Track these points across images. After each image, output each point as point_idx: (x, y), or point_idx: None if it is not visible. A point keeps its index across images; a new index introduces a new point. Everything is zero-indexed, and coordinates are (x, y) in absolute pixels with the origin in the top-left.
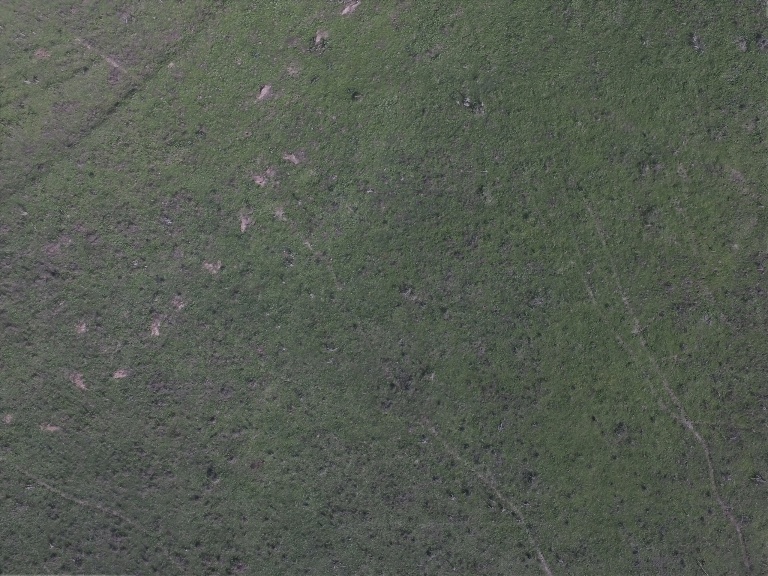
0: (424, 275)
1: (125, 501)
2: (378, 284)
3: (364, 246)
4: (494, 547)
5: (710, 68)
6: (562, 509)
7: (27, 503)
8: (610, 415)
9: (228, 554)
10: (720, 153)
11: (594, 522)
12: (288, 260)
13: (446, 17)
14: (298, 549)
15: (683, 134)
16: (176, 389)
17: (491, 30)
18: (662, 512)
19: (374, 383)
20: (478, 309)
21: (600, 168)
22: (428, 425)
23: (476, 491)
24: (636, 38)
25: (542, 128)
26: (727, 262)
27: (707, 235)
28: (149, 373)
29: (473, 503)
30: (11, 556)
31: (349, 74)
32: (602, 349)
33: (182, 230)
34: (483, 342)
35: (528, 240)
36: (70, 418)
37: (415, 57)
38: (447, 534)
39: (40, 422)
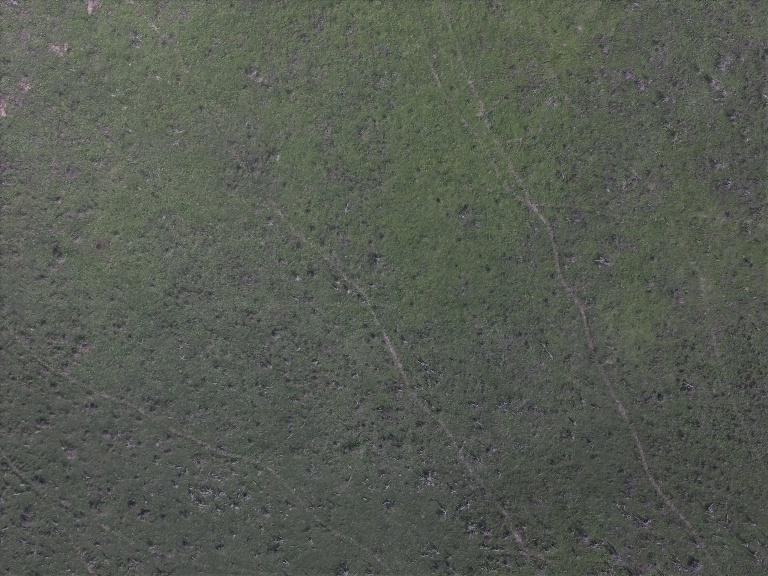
0: (270, 58)
1: None
2: (224, 67)
3: (211, 29)
4: (339, 328)
5: None
6: (407, 291)
7: None
8: (455, 198)
9: (74, 334)
10: None
11: (439, 304)
12: (134, 42)
13: None
14: (144, 330)
15: None
16: (22, 169)
17: None
18: (506, 294)
19: (220, 166)
20: (324, 92)
21: None
22: (274, 207)
23: (322, 273)
24: None
25: None
26: (572, 45)
27: (552, 18)
28: None
29: (318, 284)
30: None
31: None
32: (447, 132)
33: (29, 12)
34: (329, 125)
35: (374, 24)
36: None
37: None
38: (292, 315)
39: None
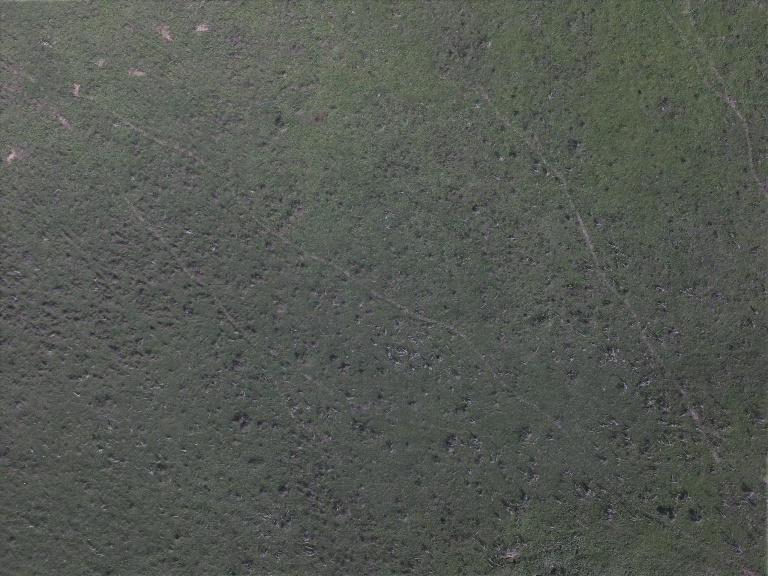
0: None
1: (200, 144)
2: None
3: None
4: (536, 208)
5: None
6: (603, 177)
7: (113, 140)
8: (656, 90)
9: (290, 198)
10: None
11: (633, 191)
12: None
13: None
14: (354, 199)
15: None
16: (252, 44)
17: None
18: (699, 185)
19: (434, 49)
20: None
21: None
22: (482, 91)
23: (523, 155)
24: None
25: None
26: None
27: None
28: (228, 28)
29: (519, 166)
30: (96, 186)
31: None
32: (653, 27)
33: None
34: (539, 16)
35: None
36: (155, 65)
37: None
38: (493, 193)
39: (129, 67)
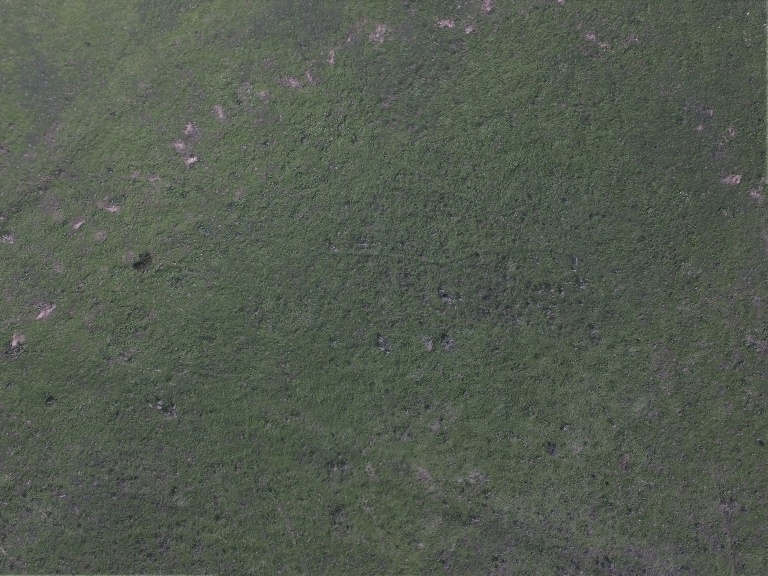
0: None
1: None
2: None
3: (58, 550)
4: None
5: (396, 369)
6: None
7: None
8: None
9: None
10: (406, 452)
11: None
12: None
13: (139, 321)
14: None
15: (370, 434)
16: None
17: (184, 332)
18: None
19: None
20: None
21: (289, 469)
22: None
23: None
24: (325, 339)
25: (234, 429)
26: (414, 560)
27: (394, 534)
28: None
29: None
30: None
31: (44, 378)
32: None
33: None
34: None
35: (219, 541)
36: None
37: (109, 361)
38: None
39: None
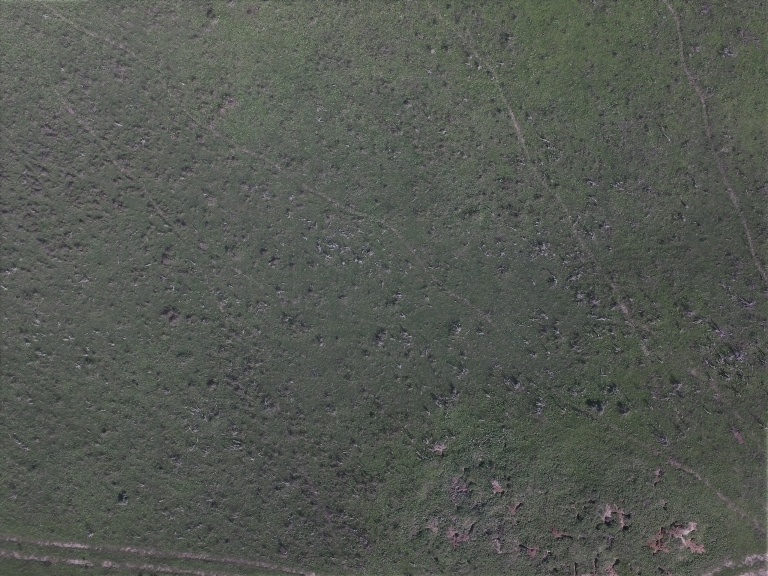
0: None
1: (131, 36)
2: None
3: None
4: (468, 102)
5: None
6: (535, 71)
7: (43, 32)
8: None
9: (221, 91)
10: None
11: (564, 84)
12: None
13: None
14: (285, 92)
15: None
16: None
17: None
18: (630, 78)
19: None
20: None
21: None
22: None
23: (455, 49)
24: None
25: None
26: None
27: None
28: None
29: (451, 59)
30: (26, 77)
31: None
32: None
33: None
34: None
35: None
36: None
37: None
38: (424, 86)
39: None
